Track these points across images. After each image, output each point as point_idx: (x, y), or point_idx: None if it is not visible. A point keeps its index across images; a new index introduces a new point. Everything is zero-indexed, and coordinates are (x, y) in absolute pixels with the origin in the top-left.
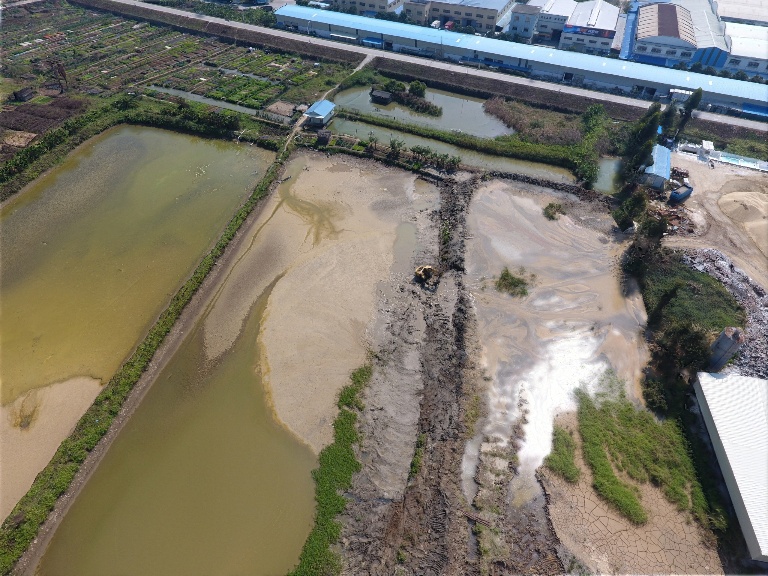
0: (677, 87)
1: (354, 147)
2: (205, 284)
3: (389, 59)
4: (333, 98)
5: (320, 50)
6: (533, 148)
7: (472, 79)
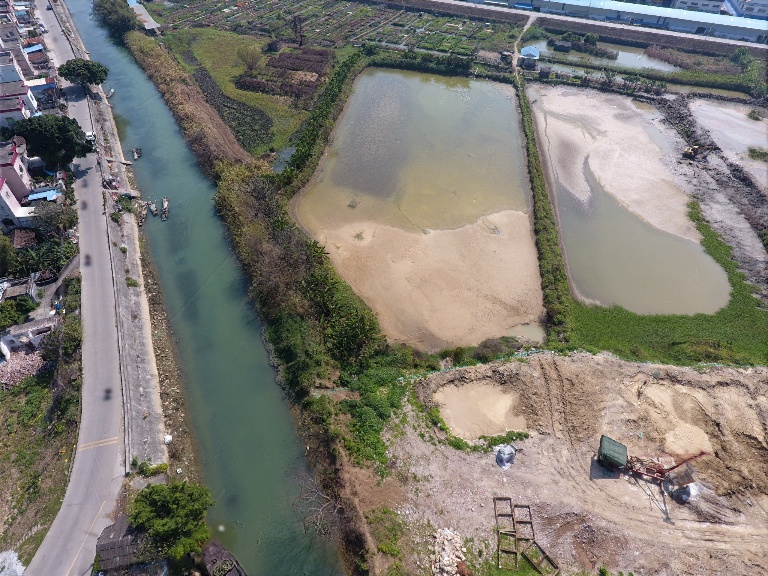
0: None
1: (572, 79)
2: (540, 161)
3: (551, 18)
4: None
5: (486, 13)
6: (712, 77)
7: (628, 32)
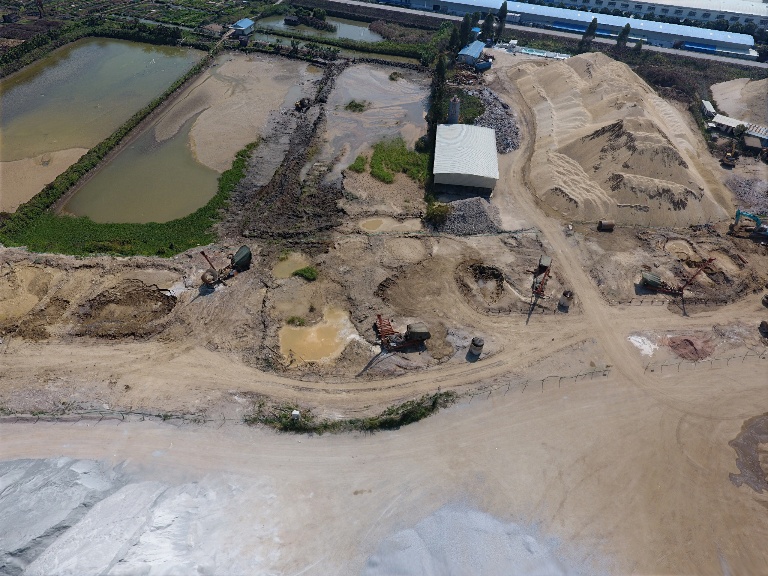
0: (509, 11)
1: (266, 47)
2: (155, 112)
3: None
4: (255, 22)
5: None
6: (394, 46)
7: (363, 9)
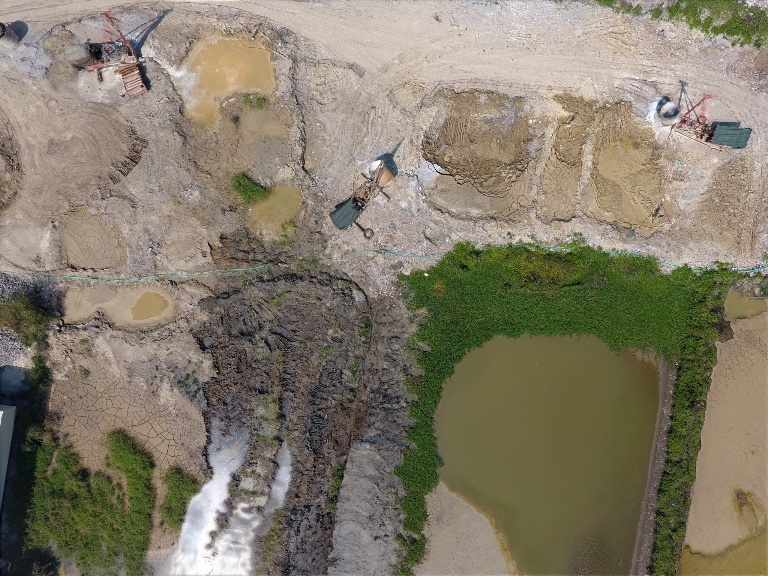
0: None
1: None
2: None
3: None
4: None
5: None
6: None
7: None
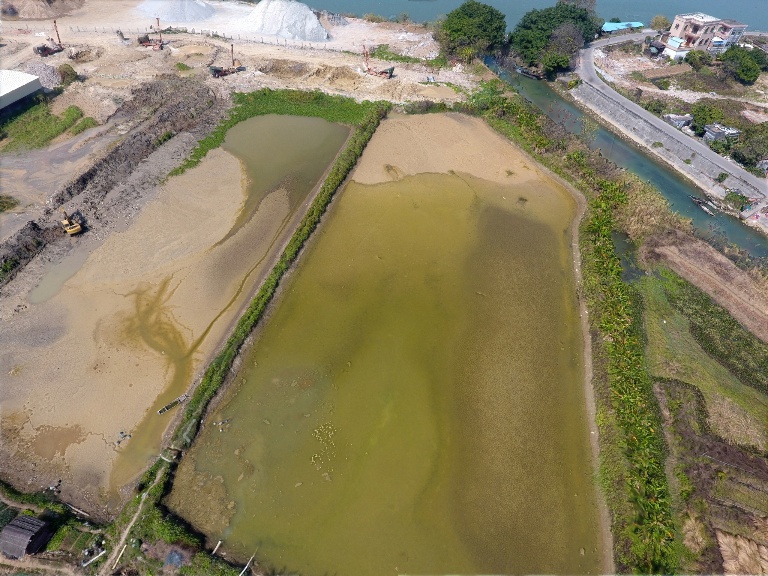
0: None
1: None
2: None
3: None
4: None
5: None
6: None
7: None
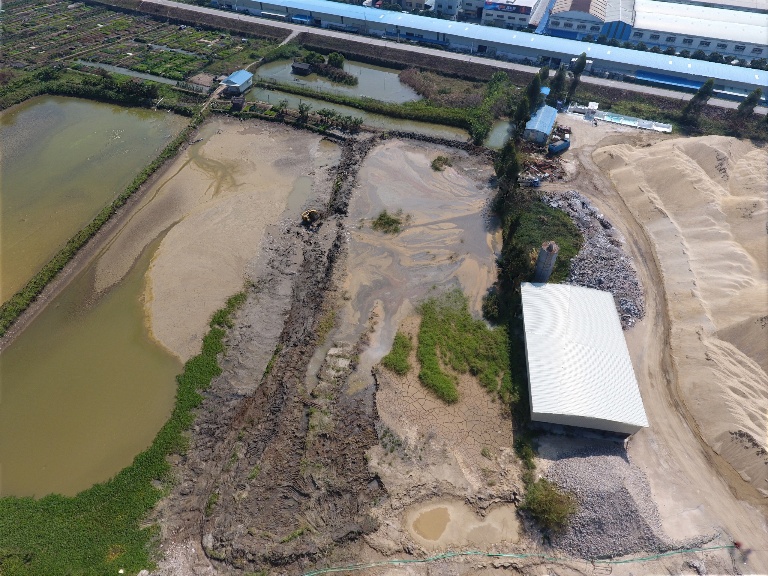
0: None
1: (266, 112)
2: (103, 230)
3: (314, 34)
4: (255, 70)
5: (249, 26)
6: (434, 111)
7: (390, 52)
